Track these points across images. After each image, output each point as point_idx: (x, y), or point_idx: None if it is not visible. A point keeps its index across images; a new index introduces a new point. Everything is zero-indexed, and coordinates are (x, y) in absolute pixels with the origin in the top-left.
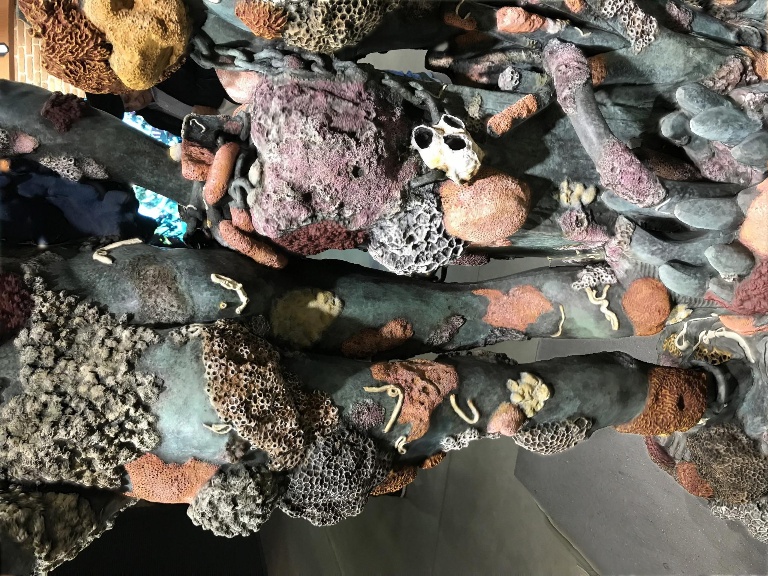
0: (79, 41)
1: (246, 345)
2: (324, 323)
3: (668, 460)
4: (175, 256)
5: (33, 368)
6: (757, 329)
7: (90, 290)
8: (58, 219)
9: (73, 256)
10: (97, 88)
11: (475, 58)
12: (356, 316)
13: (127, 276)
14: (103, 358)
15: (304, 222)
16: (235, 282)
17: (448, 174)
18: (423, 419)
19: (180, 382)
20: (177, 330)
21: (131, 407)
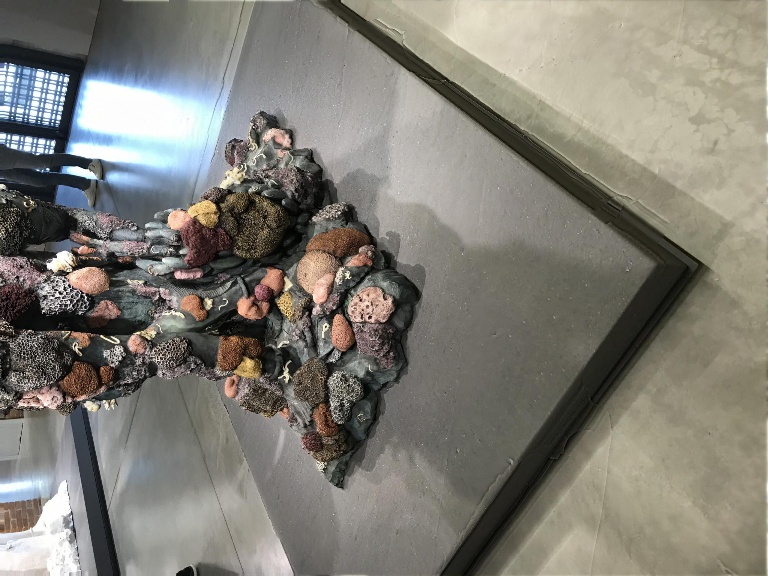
0: None
1: None
2: None
3: (313, 433)
4: None
5: None
6: (250, 301)
7: None
8: None
9: None
10: None
11: None
12: None
13: None
14: None
15: (2, 284)
16: None
17: (65, 268)
18: None
19: None
20: None
21: None
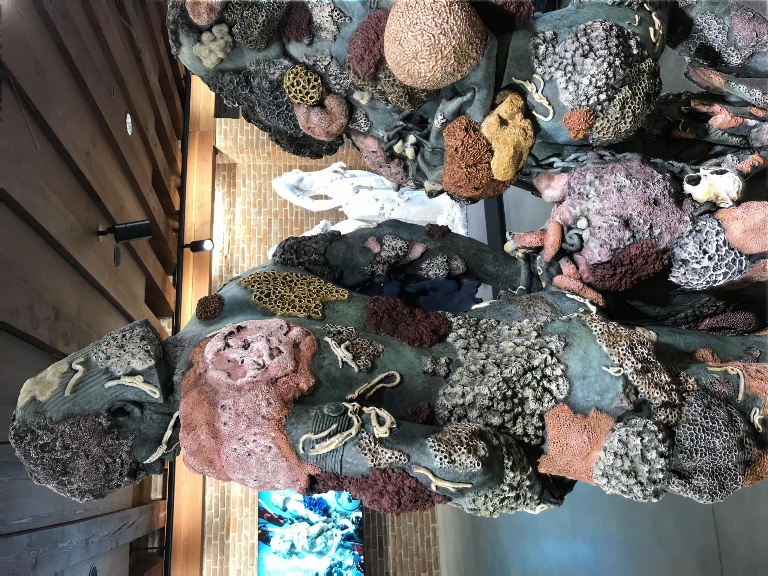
0: (480, 147)
1: None
2: None
3: None
4: None
5: (466, 350)
6: None
7: None
8: None
9: None
10: (477, 188)
11: (697, 165)
12: (671, 343)
13: (507, 304)
14: (515, 335)
15: (628, 241)
16: None
17: (719, 201)
18: (767, 393)
19: (577, 338)
20: None
21: (548, 355)
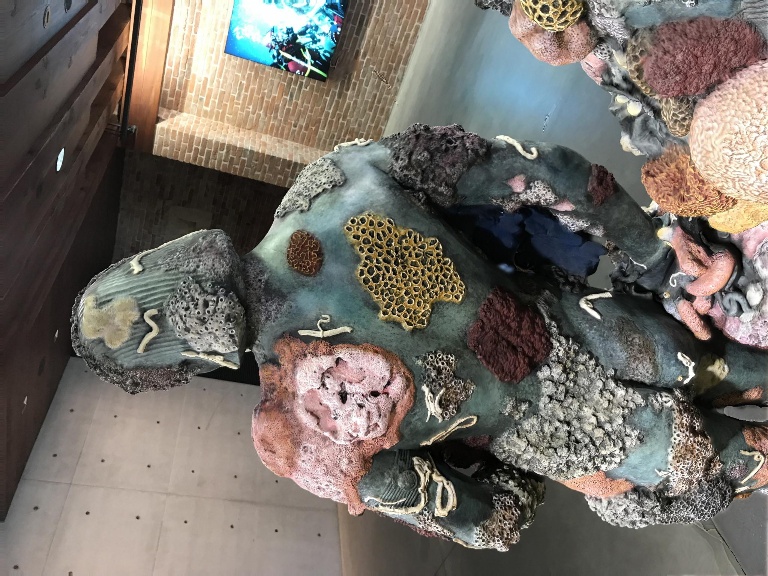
0: None
1: (696, 419)
2: (712, 383)
3: None
4: (650, 327)
5: (550, 398)
6: None
7: (582, 337)
8: (525, 240)
9: (561, 297)
10: None
11: None
12: (734, 381)
13: (616, 337)
14: (603, 407)
15: None
16: (691, 360)
17: None
18: (767, 479)
19: (654, 440)
20: (654, 397)
21: (618, 450)
